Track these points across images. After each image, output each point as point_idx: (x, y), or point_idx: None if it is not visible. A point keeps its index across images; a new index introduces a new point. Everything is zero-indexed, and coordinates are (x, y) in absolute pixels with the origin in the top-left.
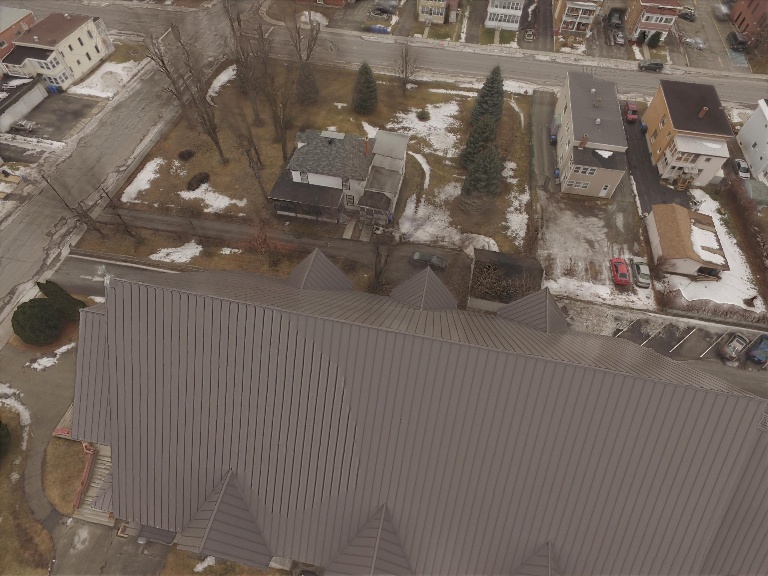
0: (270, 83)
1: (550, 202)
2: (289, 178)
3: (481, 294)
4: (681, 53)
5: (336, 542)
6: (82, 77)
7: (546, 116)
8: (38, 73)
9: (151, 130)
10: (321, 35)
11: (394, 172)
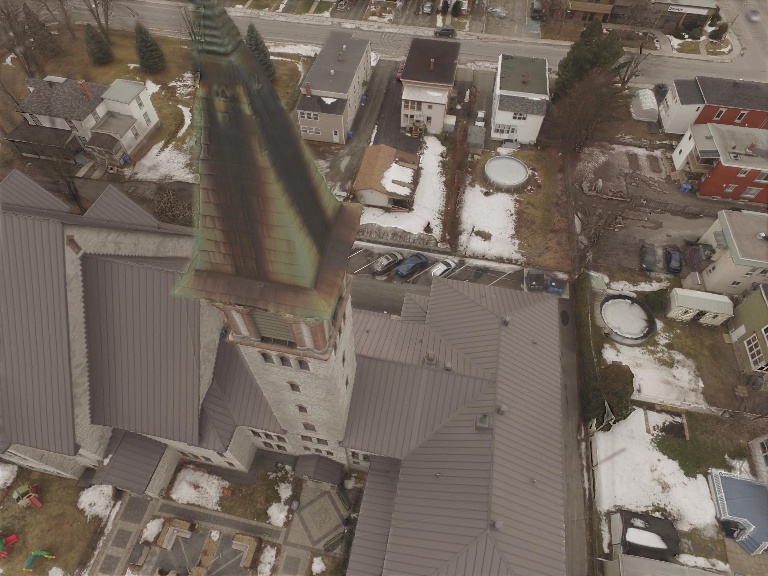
0: (4, 33)
1: None
2: (28, 122)
3: (161, 217)
4: (482, 21)
5: None
6: None
7: None
8: None
9: None
10: (146, 6)
11: (129, 117)
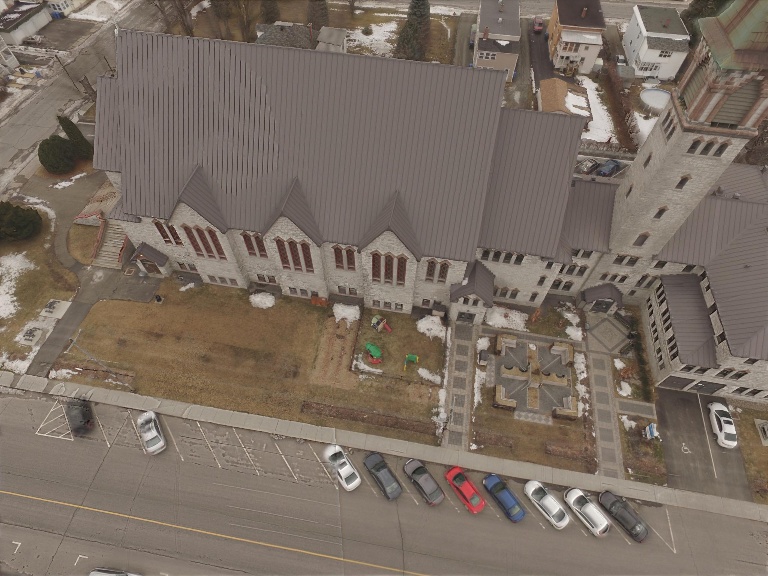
0: None
1: None
2: None
3: None
4: None
5: (268, 211)
6: (80, 7)
7: (469, 30)
8: (44, 0)
9: None
10: None
11: None
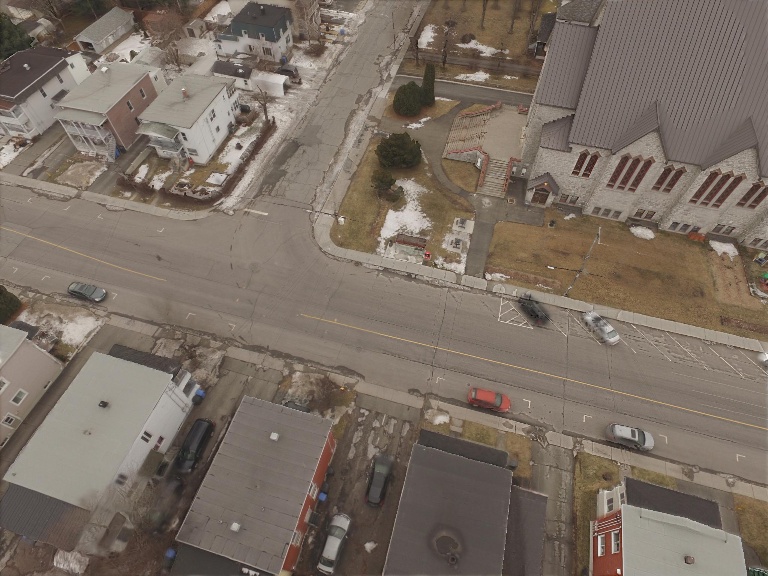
0: None
1: None
2: (550, 30)
3: None
4: None
5: (713, 146)
6: None
7: None
8: None
9: (415, 9)
10: None
11: None
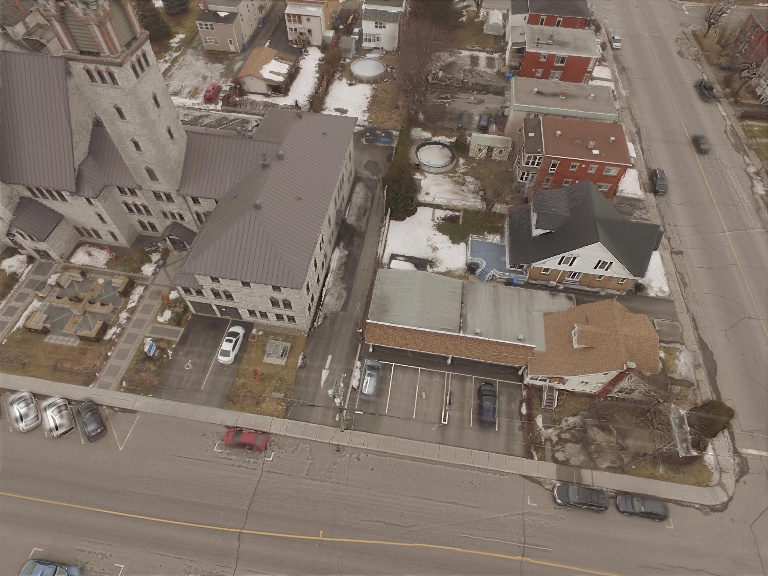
0: None
1: (192, 56)
2: None
3: None
4: None
5: None
6: None
7: None
8: None
9: None
10: None
11: None
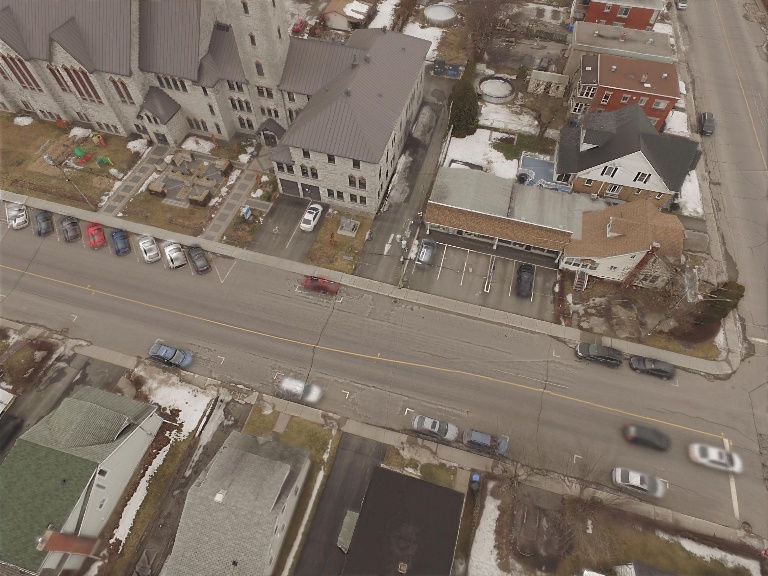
0: None
1: None
2: None
3: None
4: None
5: None
6: None
7: None
8: None
9: None
10: None
11: None
